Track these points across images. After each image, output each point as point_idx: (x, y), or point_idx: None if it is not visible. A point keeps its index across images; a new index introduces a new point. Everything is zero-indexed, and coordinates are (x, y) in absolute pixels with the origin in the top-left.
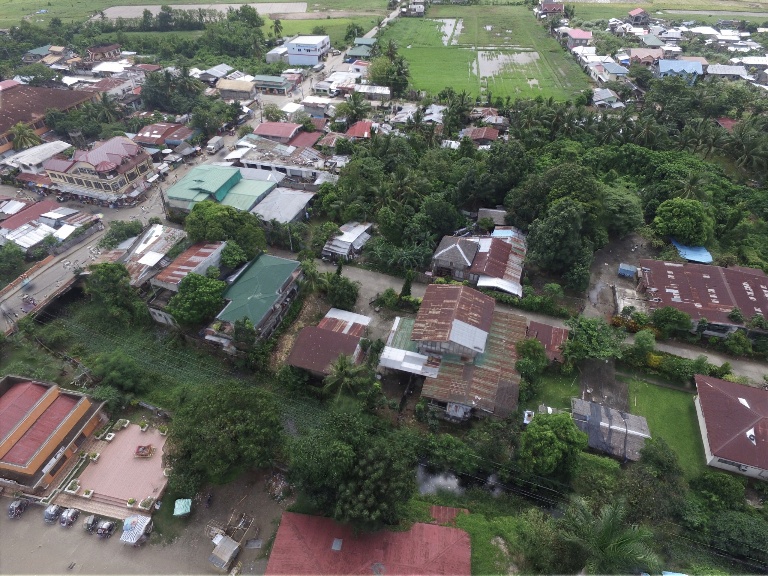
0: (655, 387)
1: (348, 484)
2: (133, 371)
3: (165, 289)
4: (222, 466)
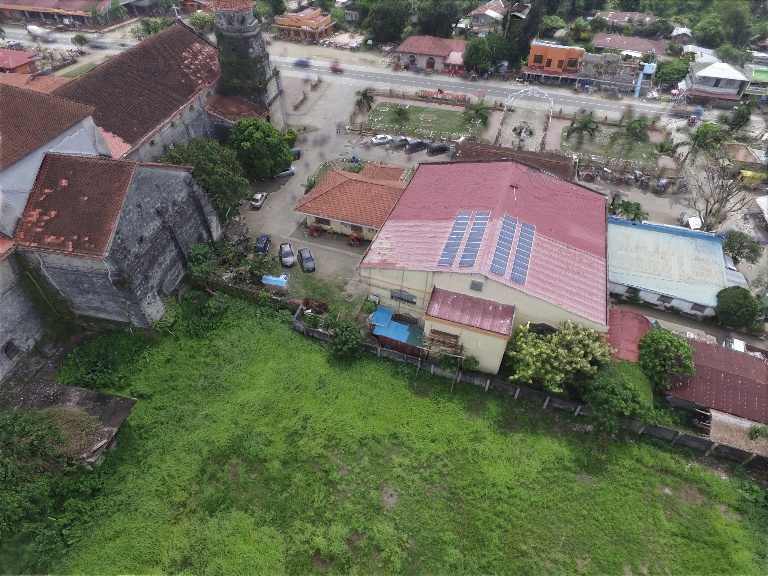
0: (580, 46)
1: None
2: None
3: (352, 5)
4: (392, 7)
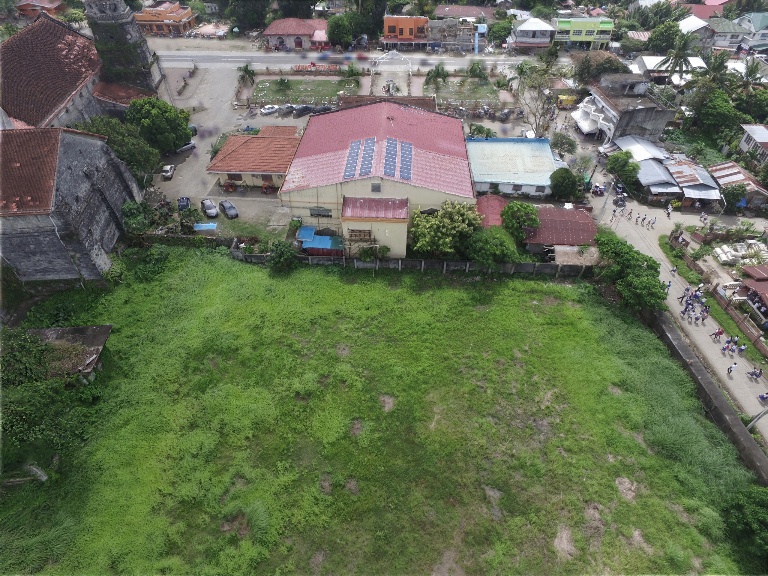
0: None
1: None
2: None
3: None
4: None
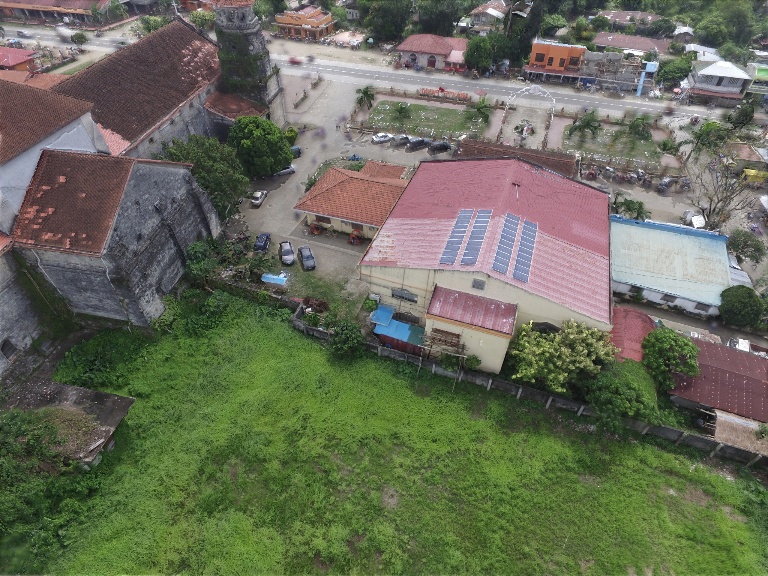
0: None
1: None
2: None
3: (352, 4)
4: (393, 5)
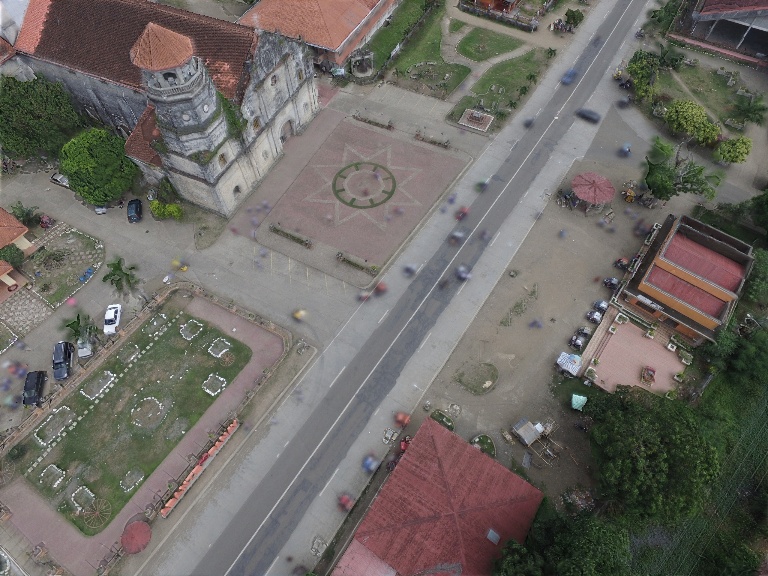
0: None
1: (541, 568)
2: (759, 371)
3: None
4: (600, 437)
